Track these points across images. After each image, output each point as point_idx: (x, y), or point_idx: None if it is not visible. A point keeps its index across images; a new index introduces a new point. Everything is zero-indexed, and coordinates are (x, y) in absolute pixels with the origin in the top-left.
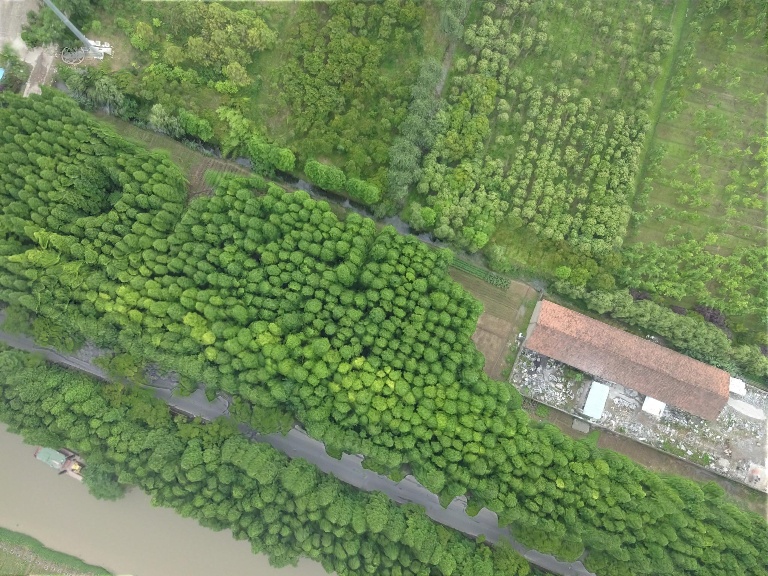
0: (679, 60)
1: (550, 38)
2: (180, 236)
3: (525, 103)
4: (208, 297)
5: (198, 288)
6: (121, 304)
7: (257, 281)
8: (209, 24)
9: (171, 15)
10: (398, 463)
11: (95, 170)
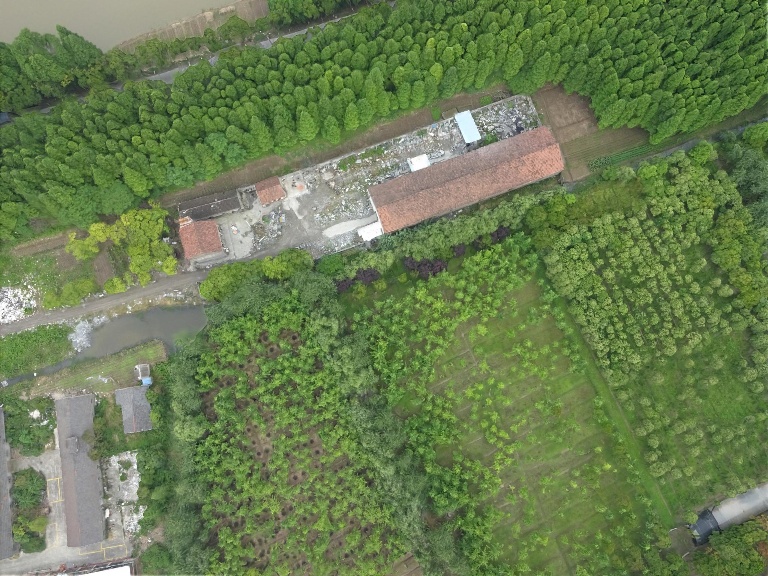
0: None
1: None
2: None
3: None
4: None
5: None
6: None
7: None
8: None
9: None
10: None
11: None
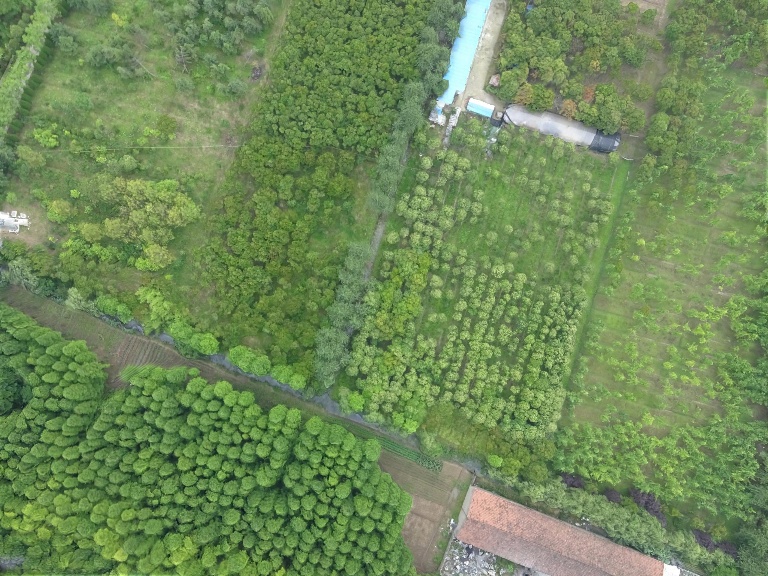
0: (618, 231)
1: (485, 210)
2: (92, 444)
3: (459, 278)
4: (120, 512)
5: (110, 501)
6: (28, 523)
7: (172, 493)
8: (127, 203)
9: (88, 189)
10: None
11: (3, 371)
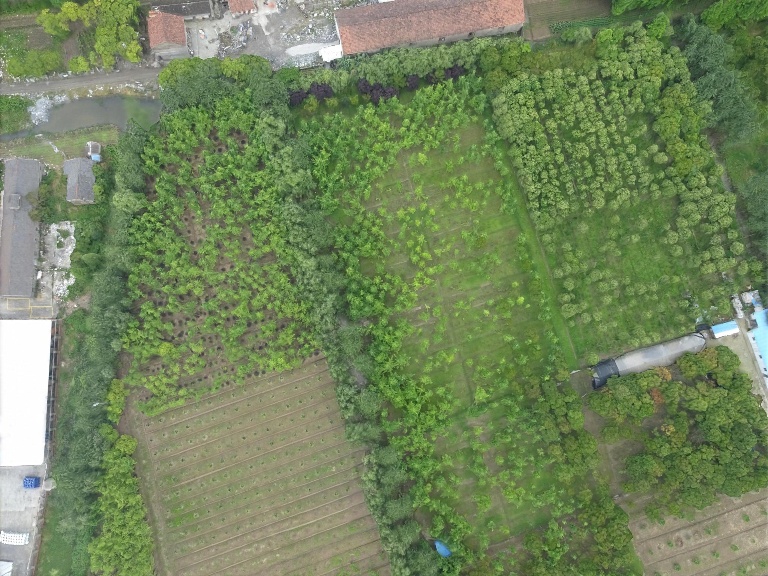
0: None
1: None
2: None
3: None
4: None
5: None
6: None
7: None
8: None
9: None
10: None
11: None
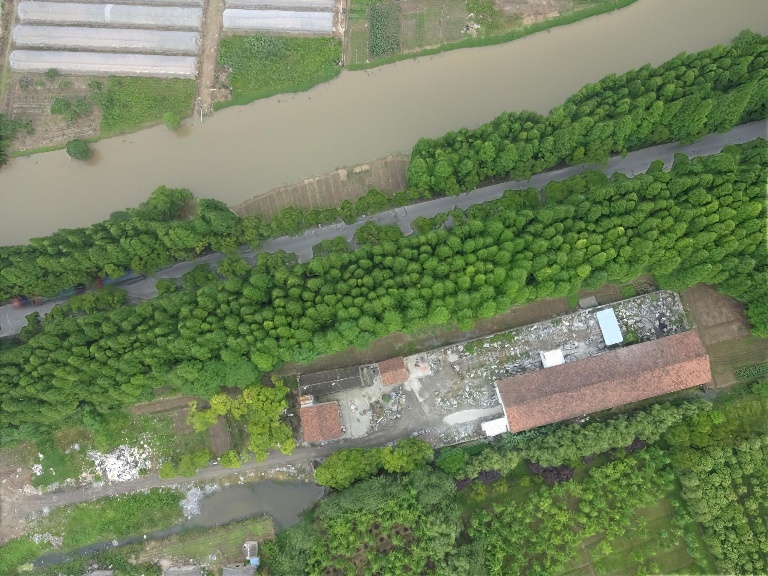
0: None
1: None
2: None
3: None
4: None
5: None
6: None
7: None
8: None
9: None
10: (764, 152)
11: None
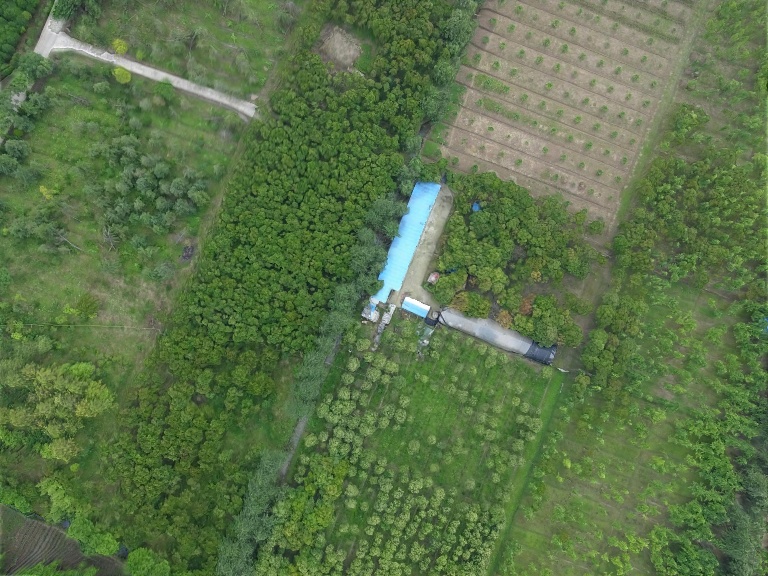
0: (544, 450)
1: (408, 420)
2: None
3: (376, 487)
4: None
5: None
6: None
7: None
8: None
9: None
10: None
11: None
